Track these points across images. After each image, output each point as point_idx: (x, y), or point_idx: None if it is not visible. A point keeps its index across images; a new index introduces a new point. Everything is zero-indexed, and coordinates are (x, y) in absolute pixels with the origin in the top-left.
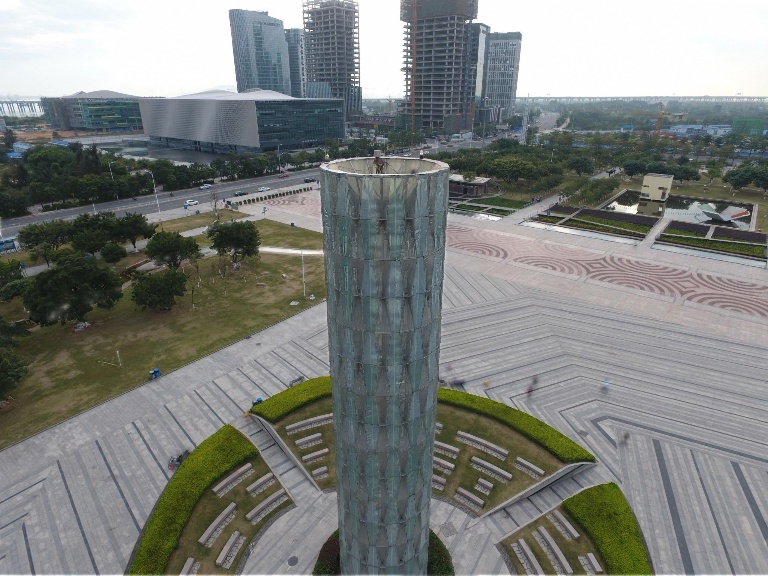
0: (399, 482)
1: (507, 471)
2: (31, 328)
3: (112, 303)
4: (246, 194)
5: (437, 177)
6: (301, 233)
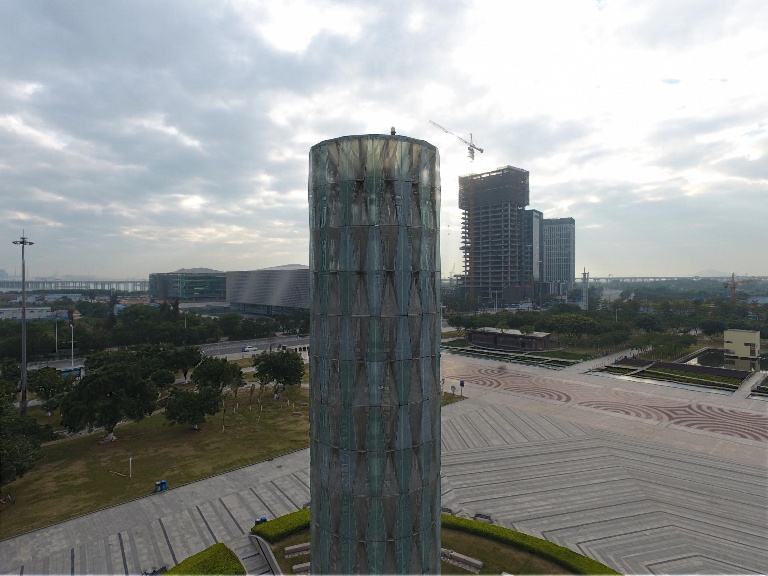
0: (384, 551)
1: None
2: (61, 439)
3: (143, 415)
4: None
5: (420, 145)
6: None
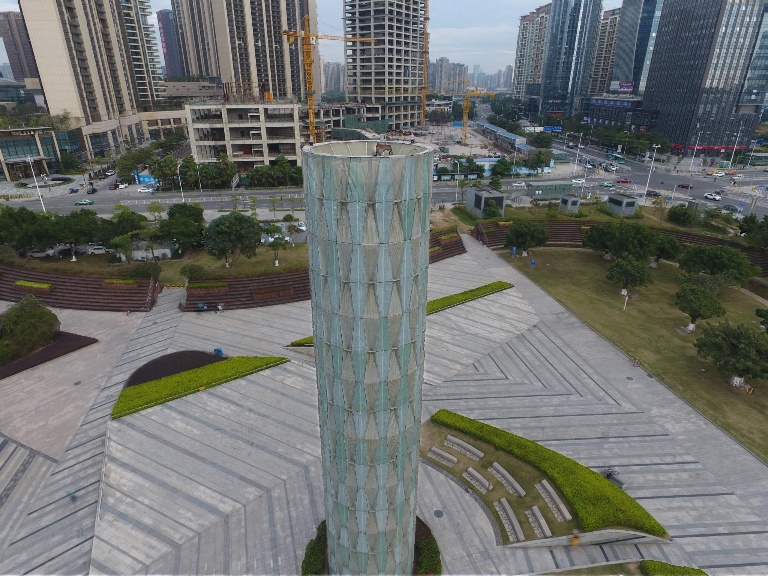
0: None
1: None
2: None
3: None
4: None
5: None
6: None
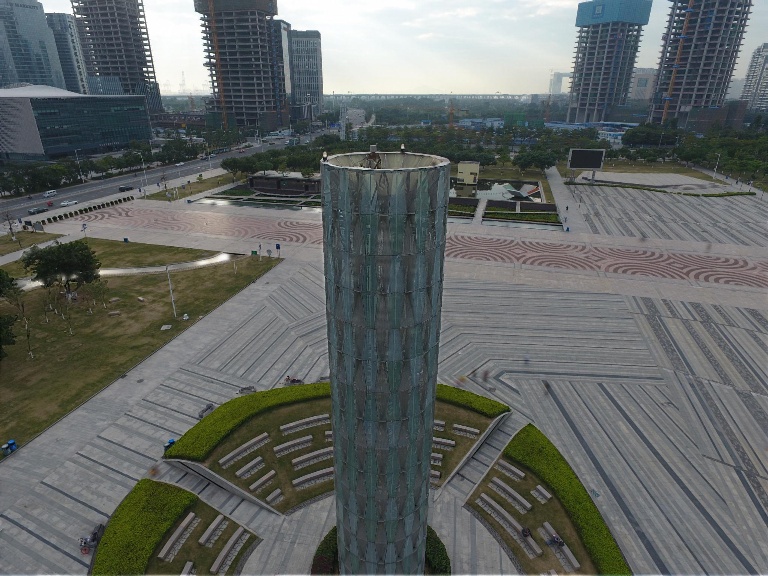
0: (416, 471)
1: (449, 439)
2: None
3: None
4: (46, 211)
5: None
6: (141, 249)
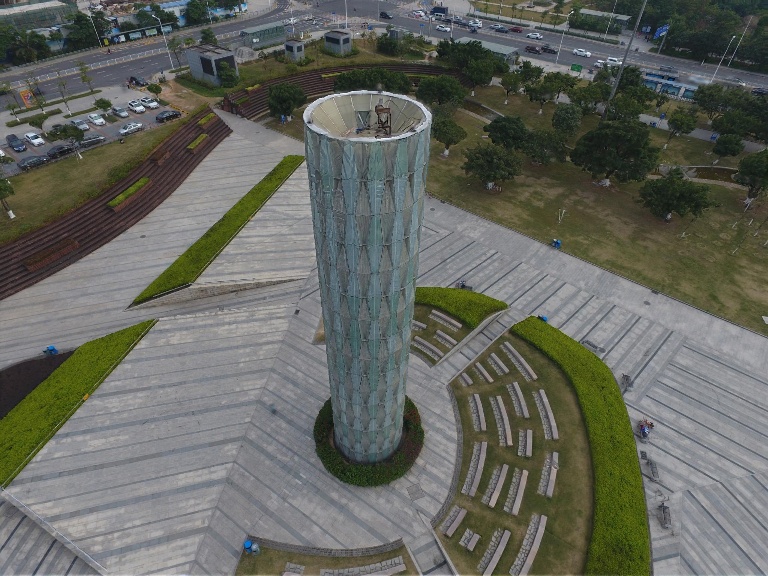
0: None
1: (494, 574)
2: None
3: (626, 179)
4: None
5: (321, 139)
6: None
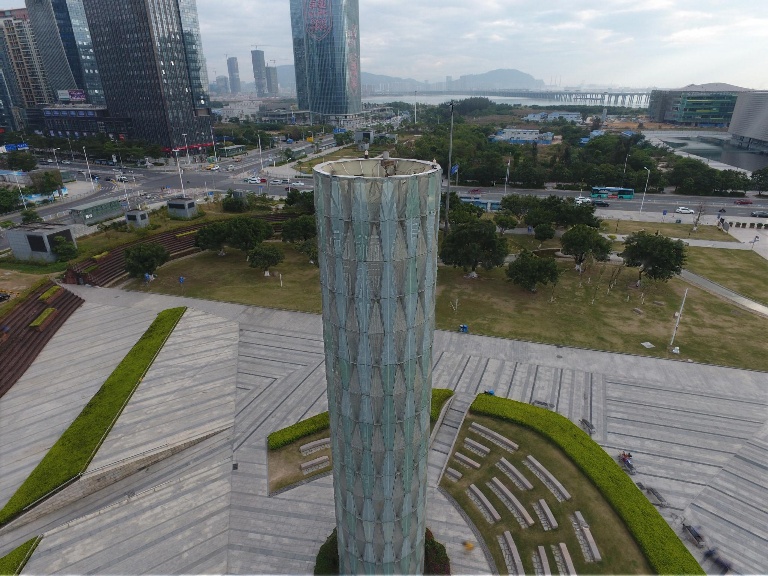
0: (339, 466)
1: None
2: None
3: (491, 266)
4: None
5: (354, 183)
6: None
